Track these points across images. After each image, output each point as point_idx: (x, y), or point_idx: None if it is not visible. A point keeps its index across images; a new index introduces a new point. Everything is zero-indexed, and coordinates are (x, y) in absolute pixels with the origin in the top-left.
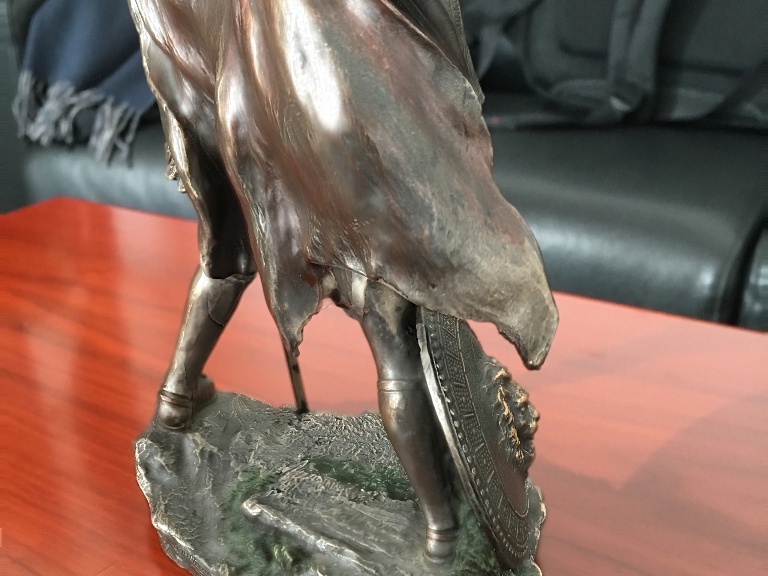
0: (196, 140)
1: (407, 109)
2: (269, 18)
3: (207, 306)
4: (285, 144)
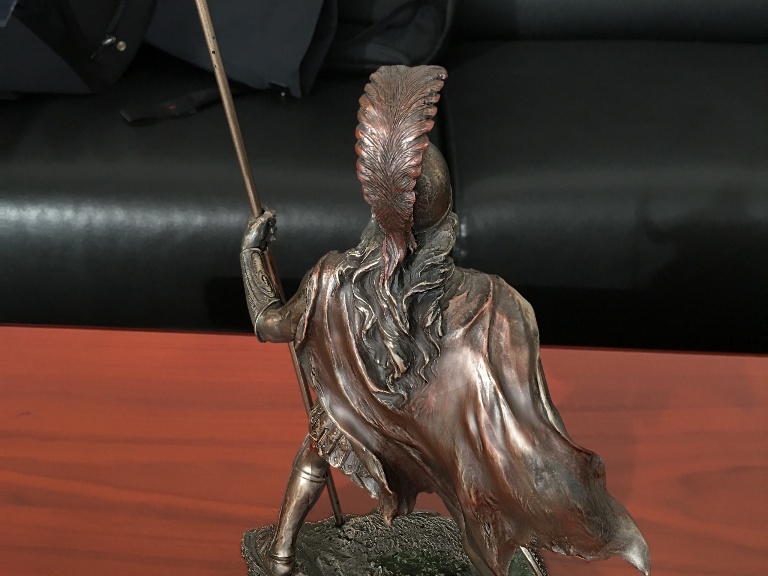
0: (385, 462)
1: (587, 486)
2: (515, 458)
3: (308, 501)
4: (525, 510)
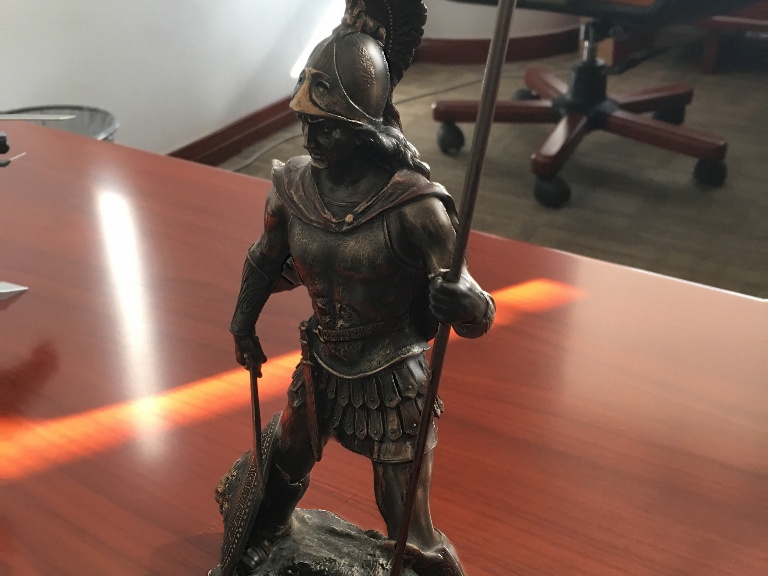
0: None
1: None
2: None
3: None
4: None
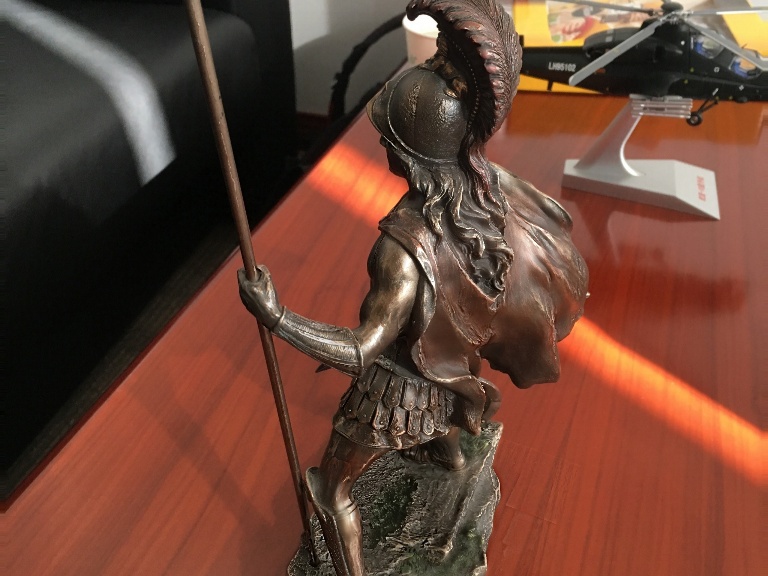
0: None
1: None
2: None
3: None
4: None
